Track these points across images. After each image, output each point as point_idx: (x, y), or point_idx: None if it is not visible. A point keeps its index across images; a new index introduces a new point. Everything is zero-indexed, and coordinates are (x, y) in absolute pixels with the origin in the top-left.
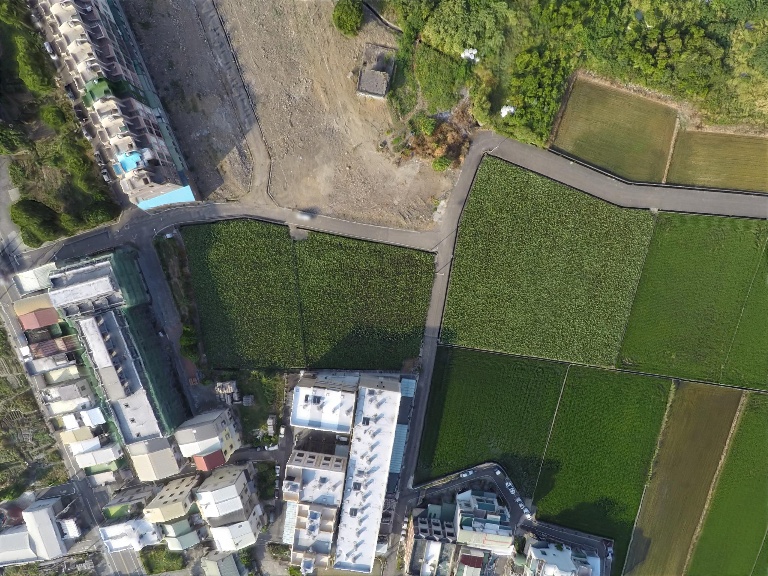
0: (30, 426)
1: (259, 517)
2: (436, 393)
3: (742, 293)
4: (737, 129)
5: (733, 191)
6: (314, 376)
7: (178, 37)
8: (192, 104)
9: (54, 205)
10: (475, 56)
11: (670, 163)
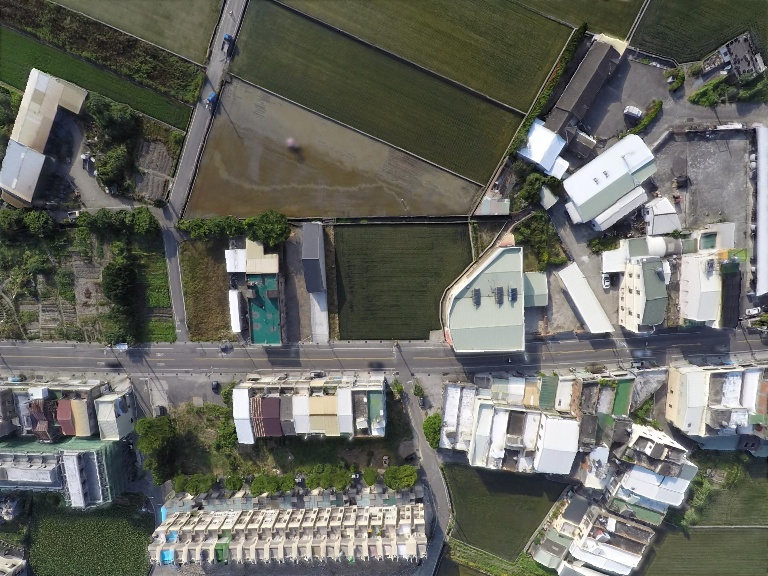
0: None
1: None
2: None
3: None
4: None
5: None
6: (16, 575)
7: (291, 560)
8: None
9: (185, 428)
10: None
11: None
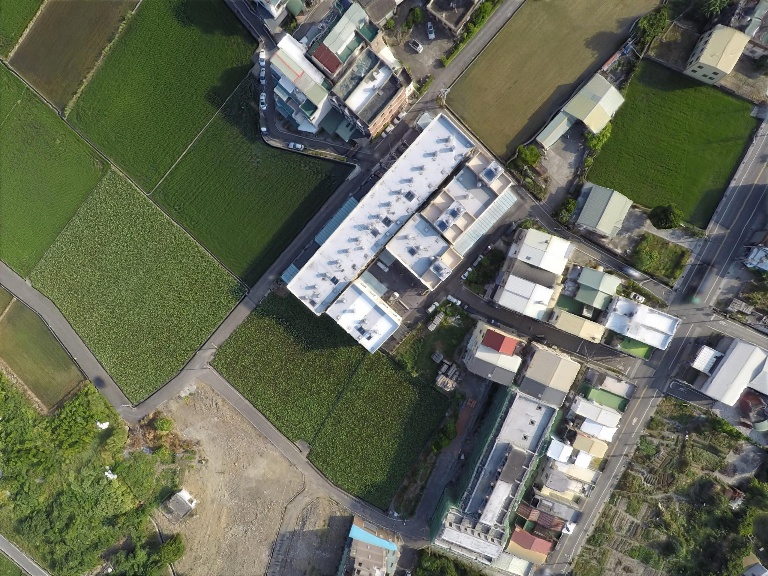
0: (648, 463)
1: None
2: (278, 247)
3: None
4: None
5: None
6: None
7: None
8: (313, 572)
9: None
10: (108, 471)
11: (5, 309)
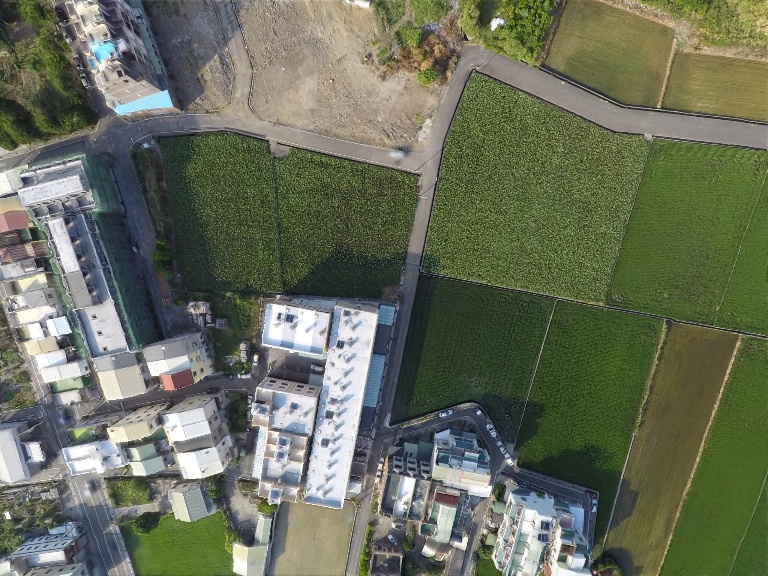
0: None
1: (229, 448)
2: (417, 325)
3: (740, 229)
4: (737, 52)
5: (732, 118)
6: (290, 300)
7: None
8: (174, 8)
9: (32, 111)
10: None
11: (666, 86)
